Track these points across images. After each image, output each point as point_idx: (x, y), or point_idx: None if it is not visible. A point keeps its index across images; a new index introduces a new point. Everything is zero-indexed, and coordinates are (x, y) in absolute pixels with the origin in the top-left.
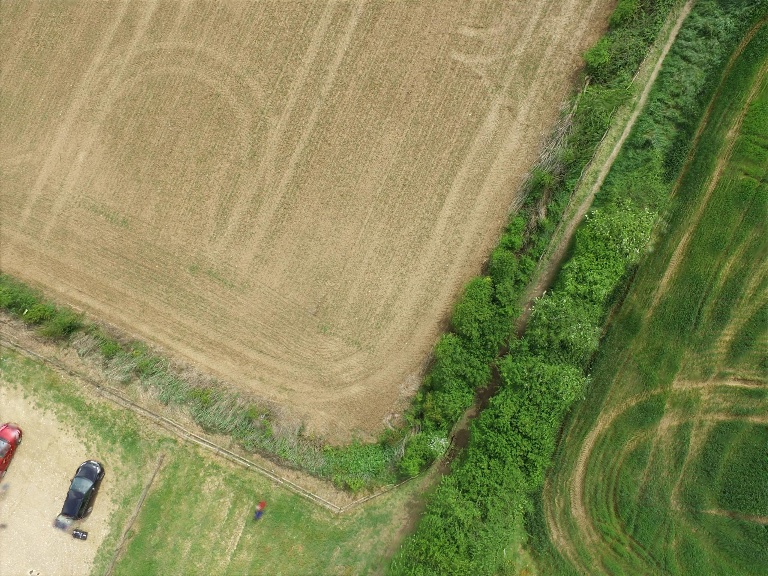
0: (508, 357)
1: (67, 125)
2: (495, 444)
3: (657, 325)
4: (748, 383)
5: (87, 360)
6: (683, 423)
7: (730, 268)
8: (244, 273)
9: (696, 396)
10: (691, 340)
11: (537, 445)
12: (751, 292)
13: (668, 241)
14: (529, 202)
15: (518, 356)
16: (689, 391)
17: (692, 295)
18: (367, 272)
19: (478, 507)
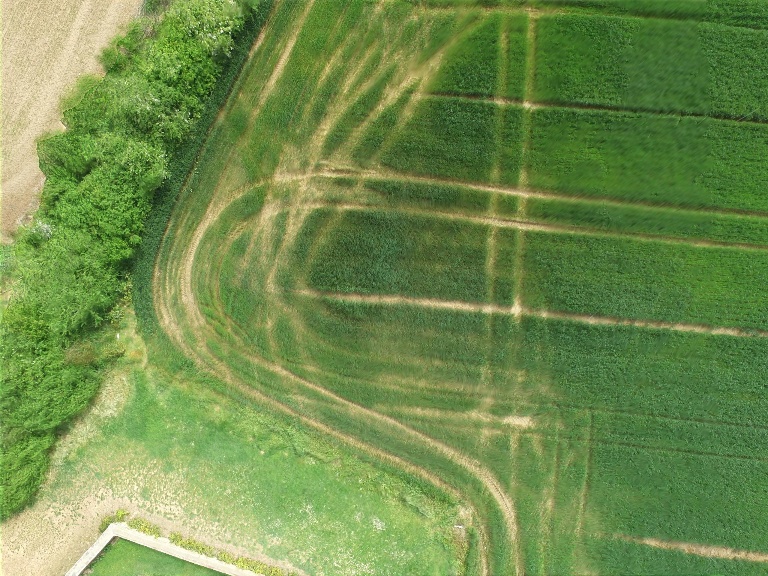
0: (87, 136)
1: None
2: (68, 214)
3: (260, 121)
4: (338, 172)
5: None
6: (280, 212)
7: (329, 67)
8: None
9: (293, 186)
10: (289, 134)
11: (107, 214)
12: (345, 88)
13: (272, 42)
14: (148, 9)
15: (94, 133)
16: (289, 183)
17: (292, 92)
18: (4, 81)
19: (40, 266)
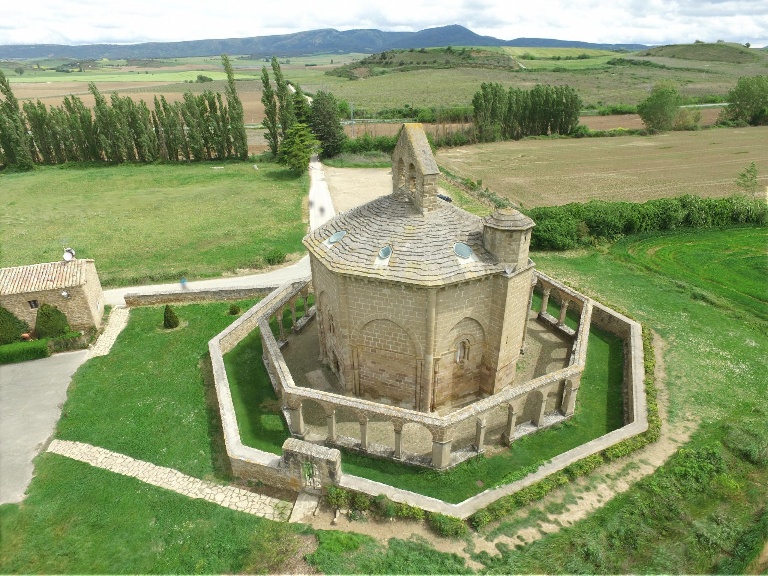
0: None
1: (525, 177)
2: None
3: None
4: None
5: (476, 193)
6: None
7: None
8: (551, 199)
9: None
10: None
11: None
12: None
13: None
14: None
15: None
16: None
17: None
18: None
19: None
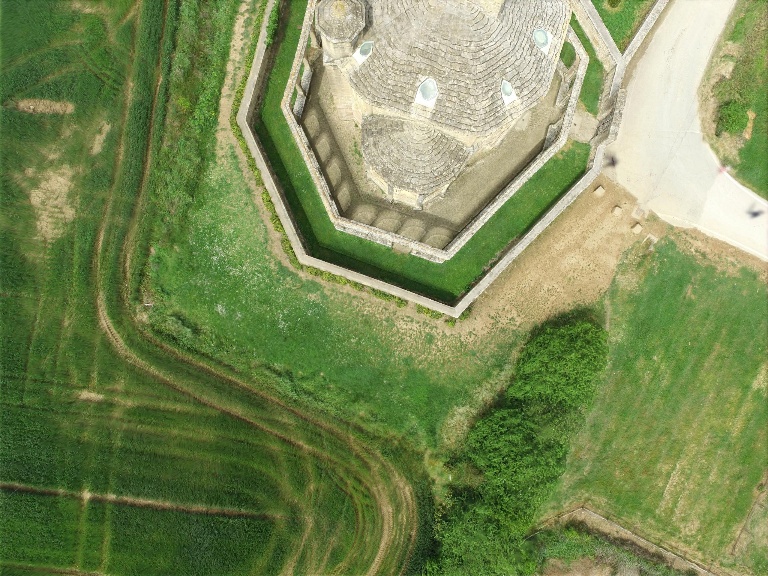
0: None
1: None
2: None
3: None
4: None
5: None
6: None
7: None
8: None
9: None
10: None
11: None
12: None
13: None
14: None
15: None
16: None
17: None
18: None
19: (492, 570)
